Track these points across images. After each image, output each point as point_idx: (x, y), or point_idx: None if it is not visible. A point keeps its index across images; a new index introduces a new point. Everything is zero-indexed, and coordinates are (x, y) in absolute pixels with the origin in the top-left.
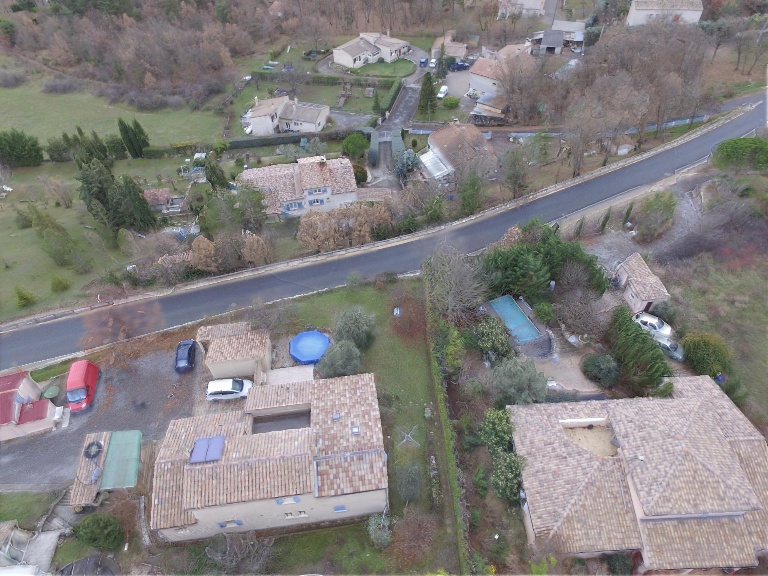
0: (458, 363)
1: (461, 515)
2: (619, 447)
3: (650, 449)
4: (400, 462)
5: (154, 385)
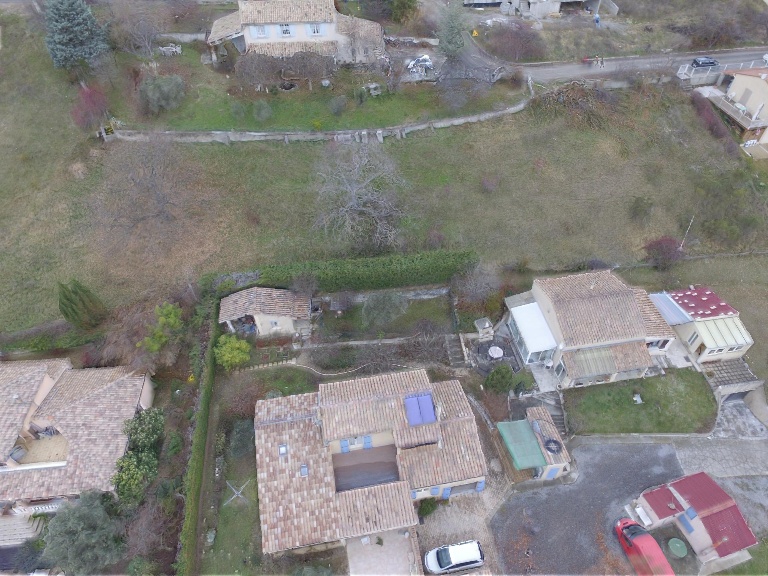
0: (148, 574)
1: (201, 396)
2: (24, 445)
3: (1, 409)
4: (253, 477)
5: (559, 569)
